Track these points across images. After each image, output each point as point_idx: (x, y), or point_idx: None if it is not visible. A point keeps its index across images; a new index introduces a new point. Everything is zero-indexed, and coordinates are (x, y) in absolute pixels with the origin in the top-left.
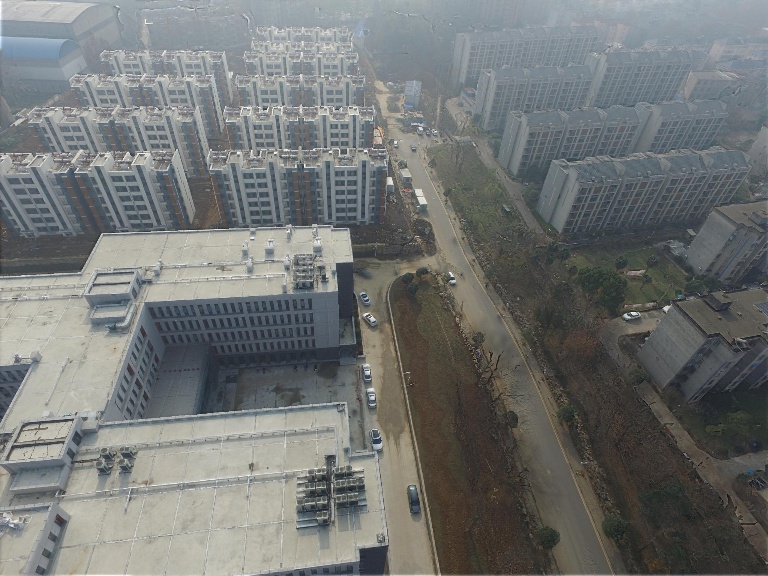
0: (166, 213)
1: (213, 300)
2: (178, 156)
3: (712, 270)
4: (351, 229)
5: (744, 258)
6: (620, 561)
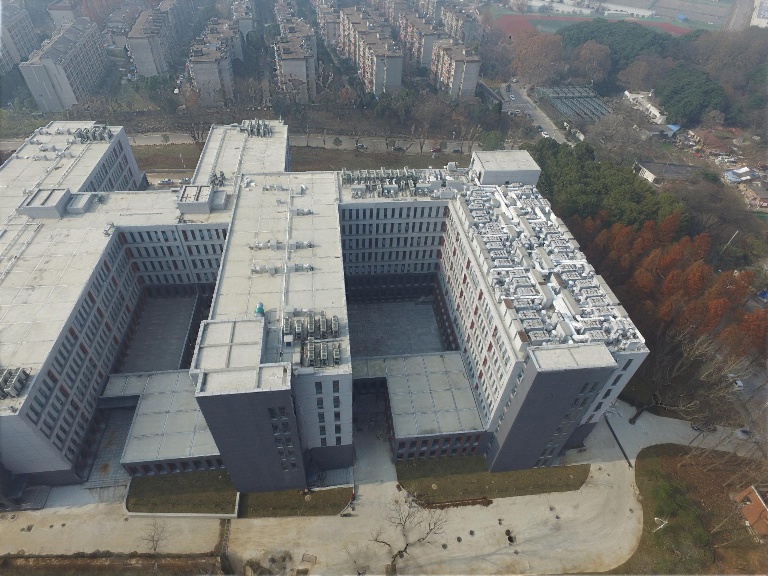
0: None
1: (95, 169)
2: None
3: (159, 72)
4: None
5: (163, 54)
6: (295, 134)
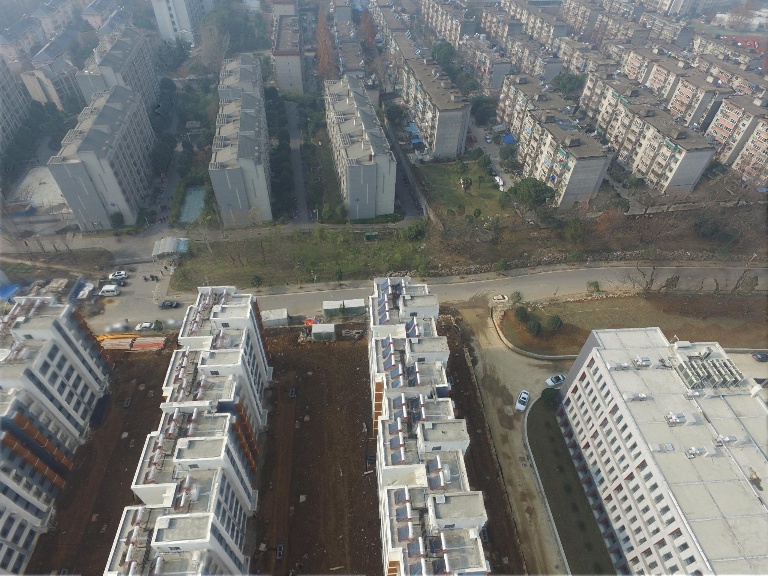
0: None
1: None
2: None
3: (457, 148)
4: None
5: None
6: (727, 263)
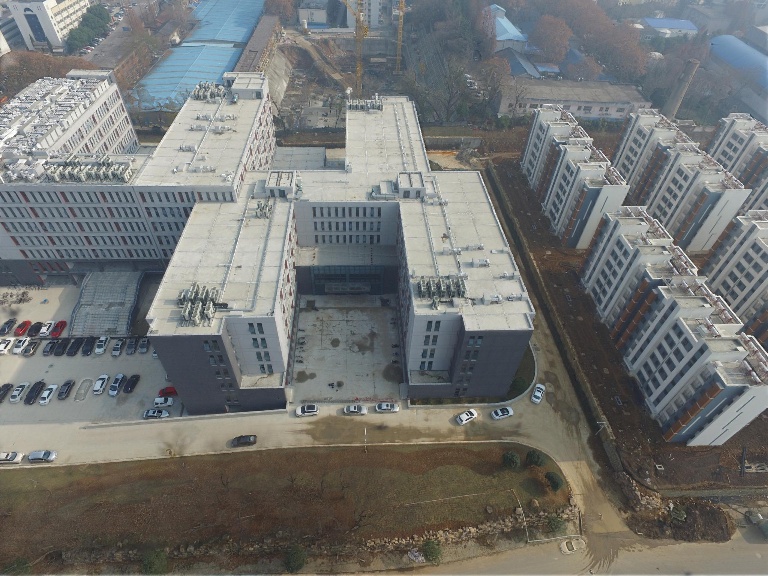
0: (567, 221)
1: None
2: (624, 192)
3: None
4: (632, 396)
5: None
6: None
